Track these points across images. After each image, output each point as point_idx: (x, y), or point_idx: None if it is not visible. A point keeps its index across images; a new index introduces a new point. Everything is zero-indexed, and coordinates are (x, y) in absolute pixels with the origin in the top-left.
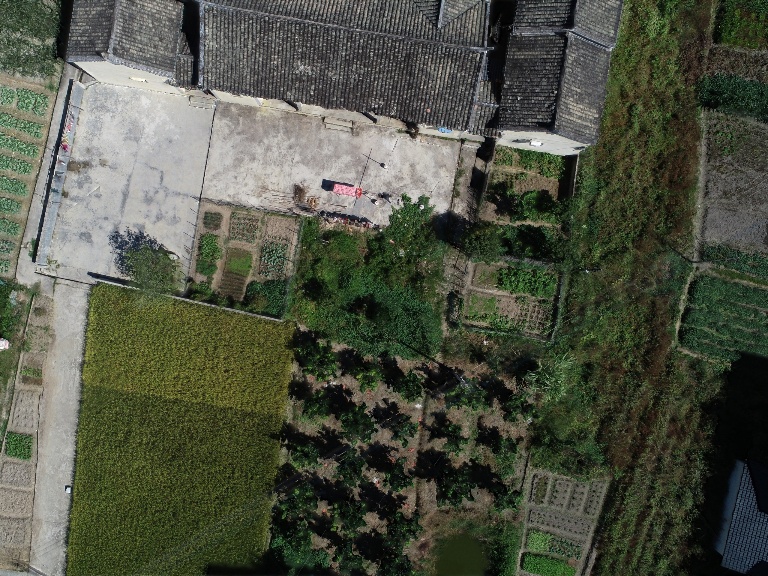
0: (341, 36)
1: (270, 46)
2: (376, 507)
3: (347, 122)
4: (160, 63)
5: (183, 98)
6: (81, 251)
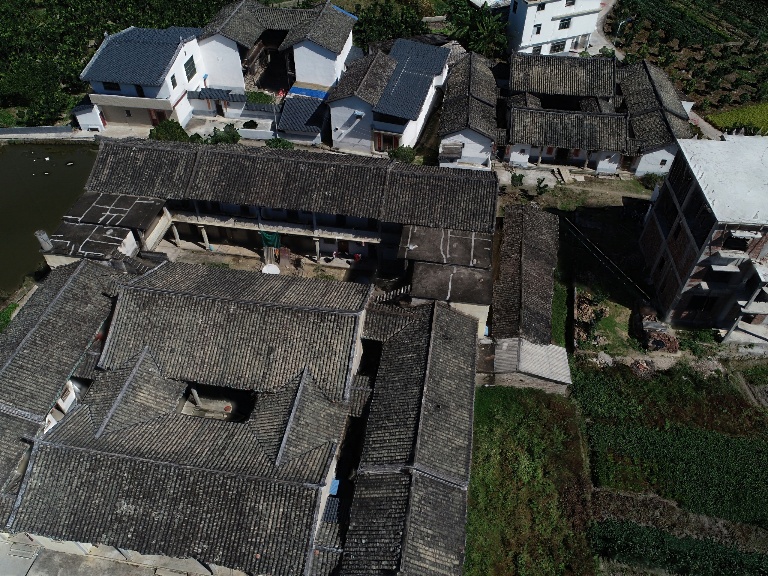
0: (171, 473)
1: (96, 484)
2: None
3: (182, 574)
4: None
5: (5, 545)
6: None
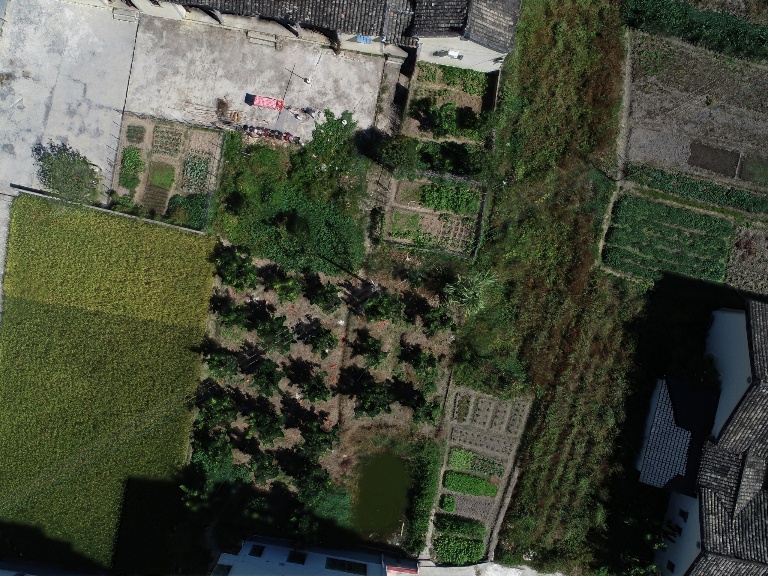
0: None
1: None
2: (298, 423)
3: (270, 36)
4: None
5: (107, 11)
6: (4, 163)
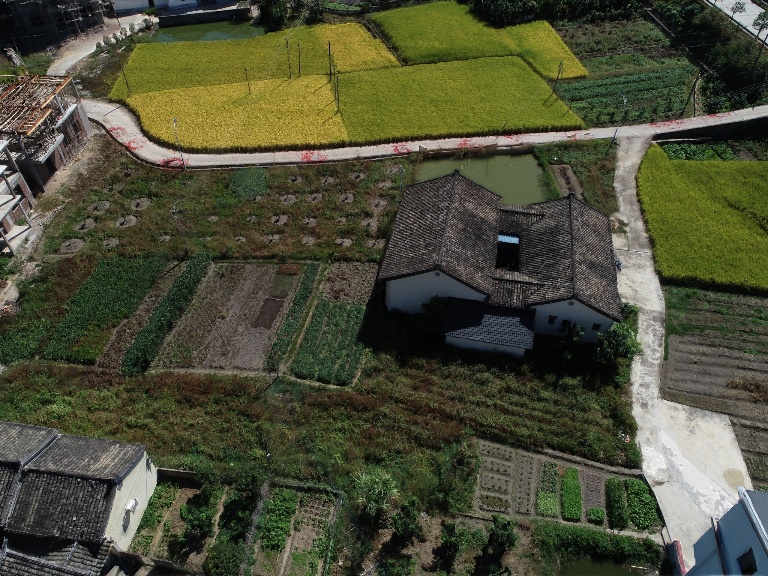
0: None
1: None
2: None
3: None
4: None
5: None
6: None
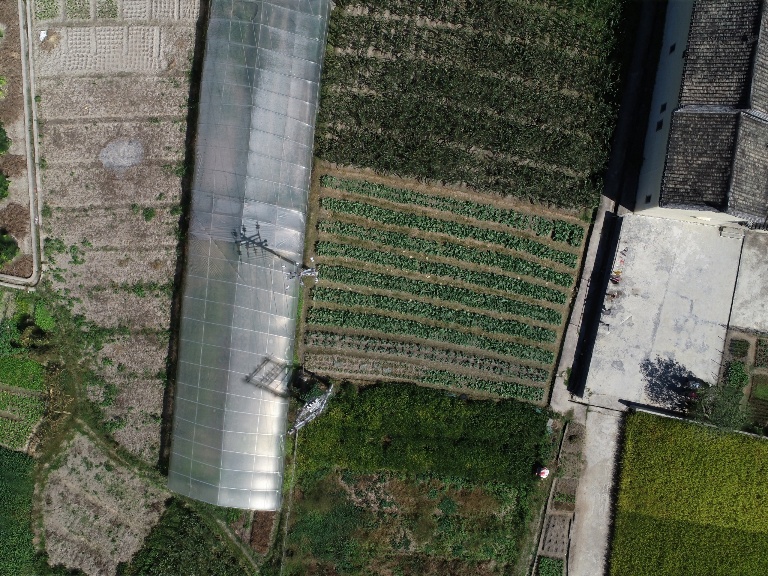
0: None
1: None
2: None
3: None
4: (756, 210)
5: (713, 228)
6: (613, 379)
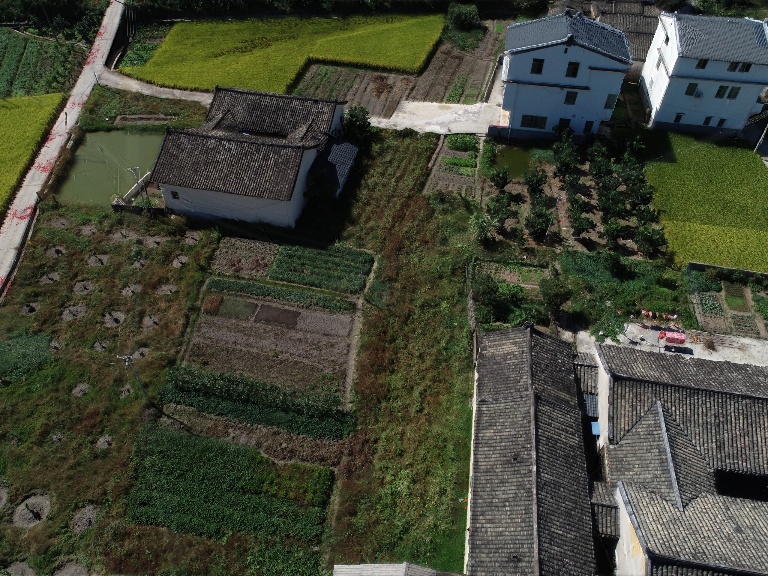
0: None
1: None
2: None
3: None
4: None
5: None
6: None
